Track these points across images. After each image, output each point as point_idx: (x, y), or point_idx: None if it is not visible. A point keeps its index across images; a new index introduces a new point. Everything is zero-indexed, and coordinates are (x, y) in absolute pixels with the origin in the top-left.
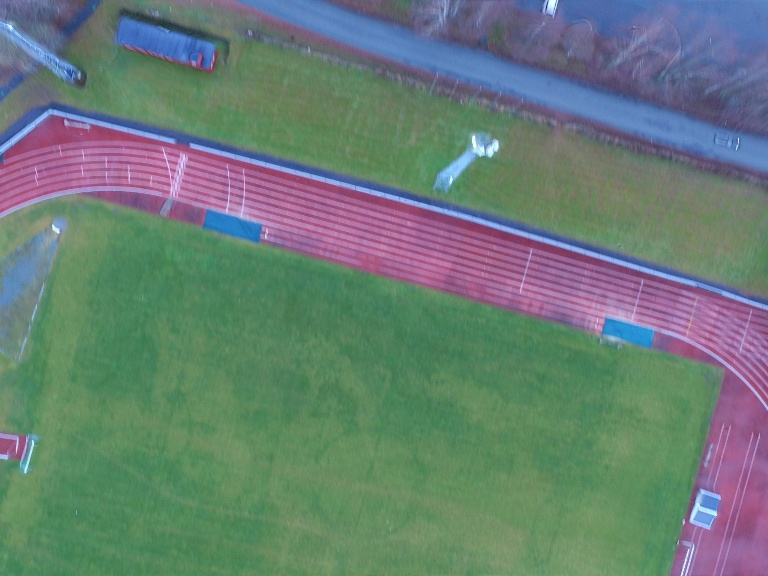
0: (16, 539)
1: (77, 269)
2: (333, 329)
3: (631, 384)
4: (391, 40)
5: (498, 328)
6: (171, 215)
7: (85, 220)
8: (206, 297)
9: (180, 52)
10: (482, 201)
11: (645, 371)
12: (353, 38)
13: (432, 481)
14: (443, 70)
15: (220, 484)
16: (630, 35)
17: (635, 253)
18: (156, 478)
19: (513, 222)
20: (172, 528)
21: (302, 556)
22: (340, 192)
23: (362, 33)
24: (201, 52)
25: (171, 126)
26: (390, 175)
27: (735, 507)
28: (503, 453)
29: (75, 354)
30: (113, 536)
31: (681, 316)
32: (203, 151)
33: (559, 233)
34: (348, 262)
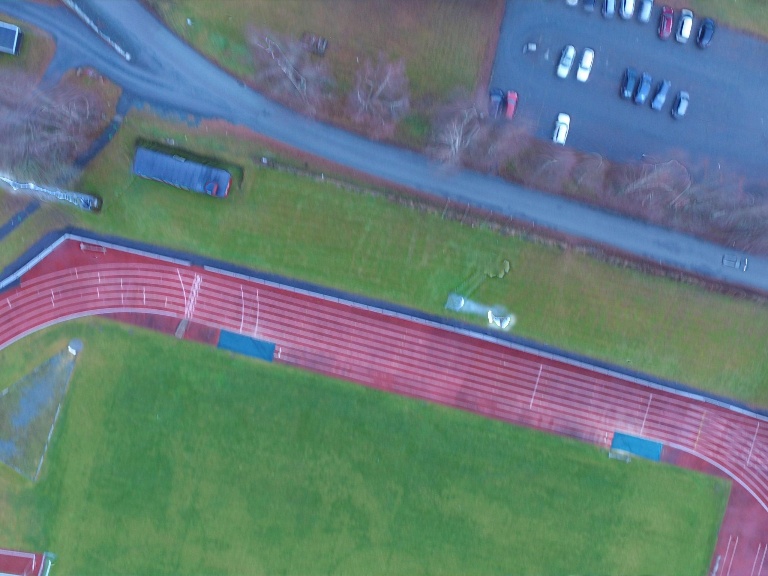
0: None
1: (93, 389)
2: (346, 446)
3: (640, 497)
4: (403, 166)
5: (508, 443)
6: (186, 336)
7: (101, 341)
8: (220, 416)
9: (195, 181)
10: None
11: (654, 484)
12: (366, 164)
13: None
14: (455, 195)
15: None
16: (640, 168)
17: (644, 368)
18: None
19: (523, 339)
20: None
21: None
22: (352, 311)
23: (375, 160)
24: (216, 181)
25: (186, 248)
26: (402, 294)
27: None
28: (513, 566)
29: (91, 473)
30: None
31: (689, 429)
32: (217, 273)
33: (569, 349)
34: (360, 380)
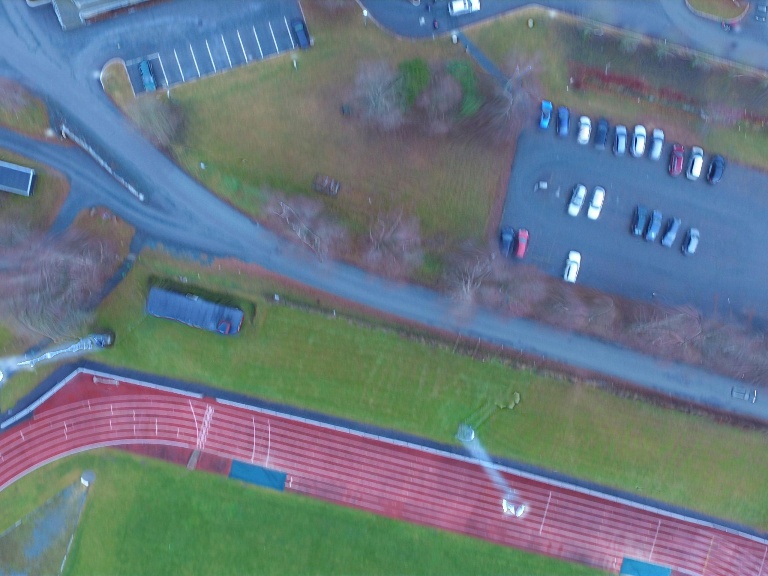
0: None
1: (105, 520)
2: (356, 574)
3: None
4: (415, 302)
5: (518, 569)
6: (198, 466)
7: (113, 472)
8: (232, 545)
9: (208, 320)
10: (503, 447)
11: None
12: (378, 301)
13: None
14: (466, 330)
15: None
16: (651, 312)
17: (653, 495)
18: None
19: (533, 467)
20: None
21: None
22: (363, 440)
23: (386, 296)
24: (229, 321)
25: (198, 379)
26: (413, 424)
27: None
28: None
29: None
30: None
31: (698, 554)
32: (229, 405)
33: (578, 476)
34: (371, 508)
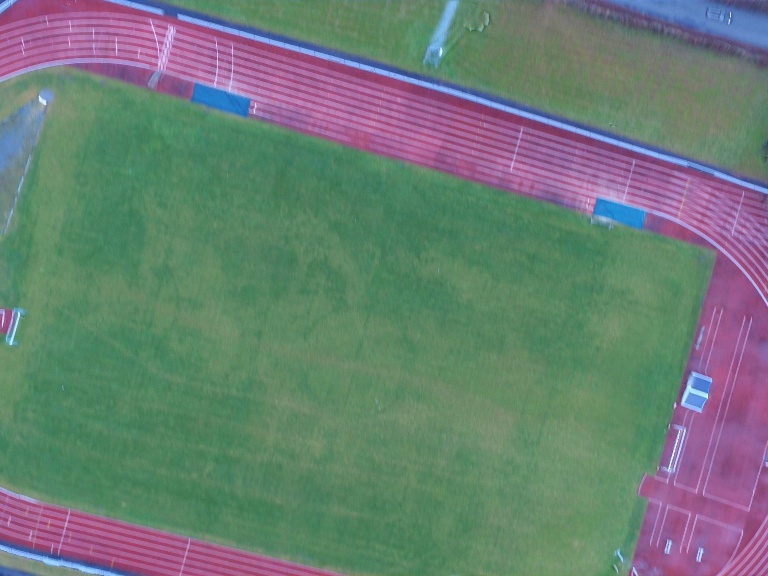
0: (2, 414)
1: (64, 141)
2: (322, 205)
3: (622, 265)
4: None
5: (488, 207)
6: (159, 88)
7: (72, 92)
8: (194, 171)
9: None
10: (472, 77)
11: (636, 252)
12: None
13: (421, 360)
14: None
15: (208, 361)
16: None
17: (627, 132)
18: (143, 354)
19: (504, 99)
20: (159, 405)
21: (290, 435)
22: (329, 67)
23: None
24: None
25: None
26: (380, 50)
27: (727, 391)
28: (493, 333)
29: (62, 227)
30: (100, 412)
31: (673, 197)
32: (191, 23)
33: (550, 111)
34: (337, 138)
